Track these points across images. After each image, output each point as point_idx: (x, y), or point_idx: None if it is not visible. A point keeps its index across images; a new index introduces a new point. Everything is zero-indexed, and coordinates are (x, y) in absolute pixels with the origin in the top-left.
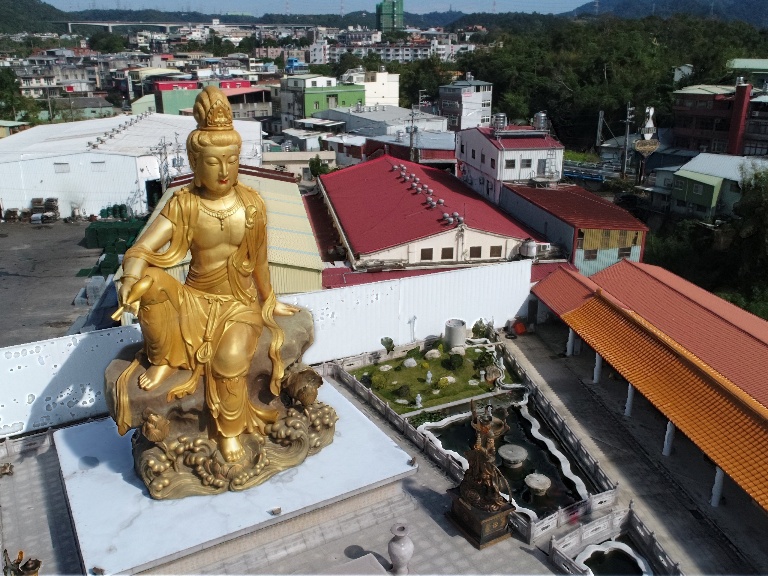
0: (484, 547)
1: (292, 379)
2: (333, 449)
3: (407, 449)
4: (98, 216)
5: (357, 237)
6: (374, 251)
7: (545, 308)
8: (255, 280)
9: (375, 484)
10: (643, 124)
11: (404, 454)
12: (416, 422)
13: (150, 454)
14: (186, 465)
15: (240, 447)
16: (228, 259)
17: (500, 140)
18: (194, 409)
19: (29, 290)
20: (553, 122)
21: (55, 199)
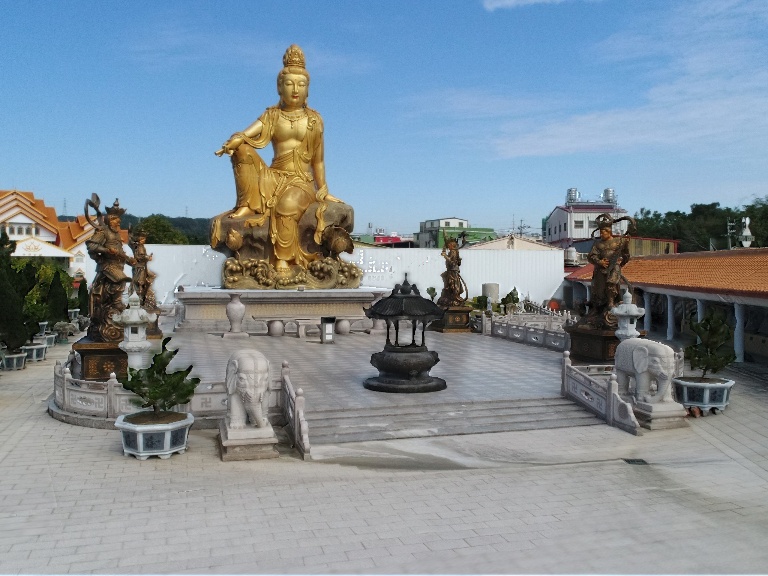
0: (447, 332)
1: (329, 232)
2: (355, 289)
3: None
4: None
5: None
6: None
7: (579, 295)
8: (314, 175)
9: None
10: (740, 233)
11: None
12: None
13: (229, 259)
14: (251, 275)
15: (288, 267)
16: (294, 148)
17: (572, 208)
18: (261, 239)
19: None
20: (653, 235)
21: None
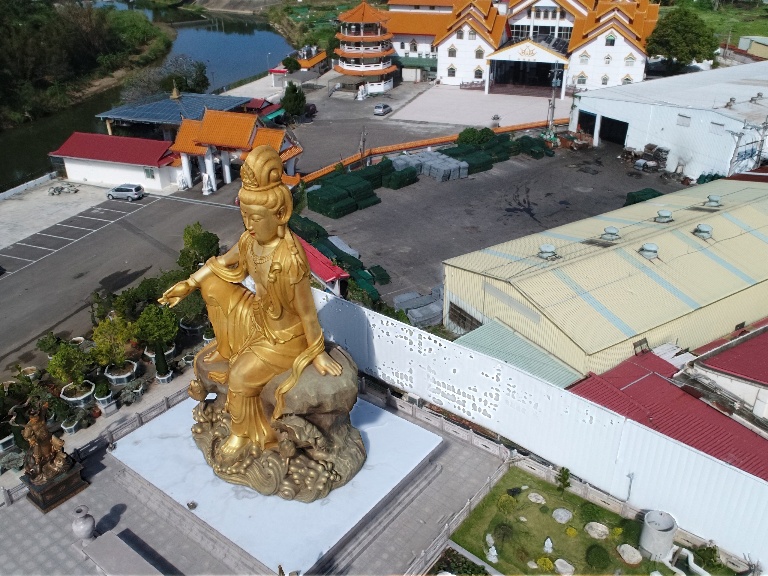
0: None
1: None
2: (297, 508)
3: (396, 575)
4: (694, 180)
5: (765, 339)
6: (715, 368)
7: None
8: None
9: (254, 558)
10: None
11: (309, 564)
12: (461, 567)
13: None
14: None
15: (236, 445)
16: None
17: None
18: None
19: (513, 233)
20: None
21: (665, 150)
